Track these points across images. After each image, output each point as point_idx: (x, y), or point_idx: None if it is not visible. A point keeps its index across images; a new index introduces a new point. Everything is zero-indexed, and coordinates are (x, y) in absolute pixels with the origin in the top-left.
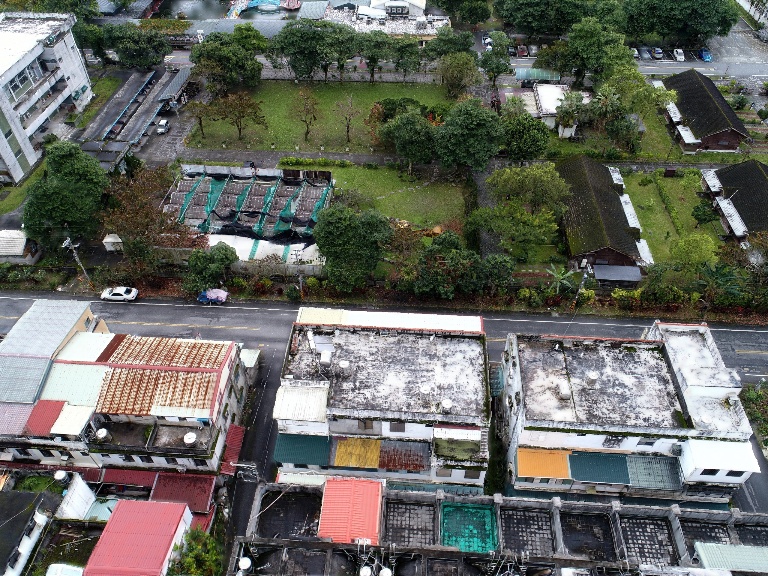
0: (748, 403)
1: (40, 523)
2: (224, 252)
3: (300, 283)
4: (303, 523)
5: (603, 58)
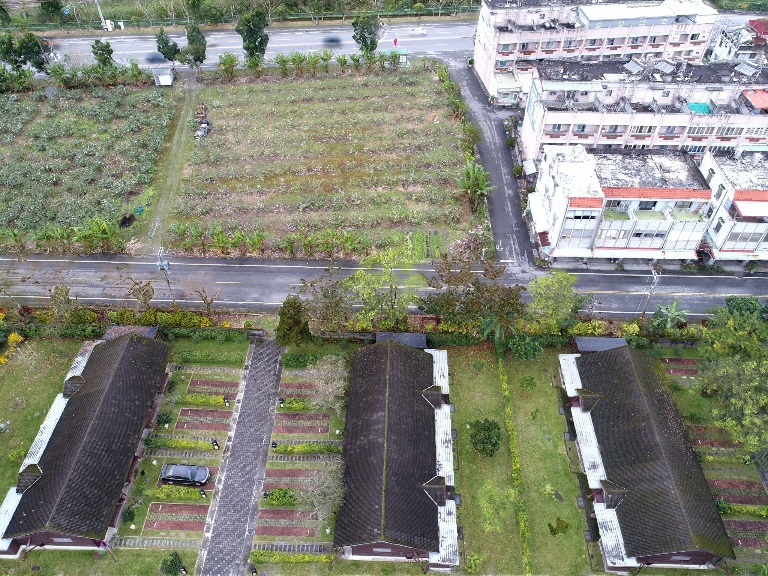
0: None
1: None
2: None
3: None
4: None
5: None
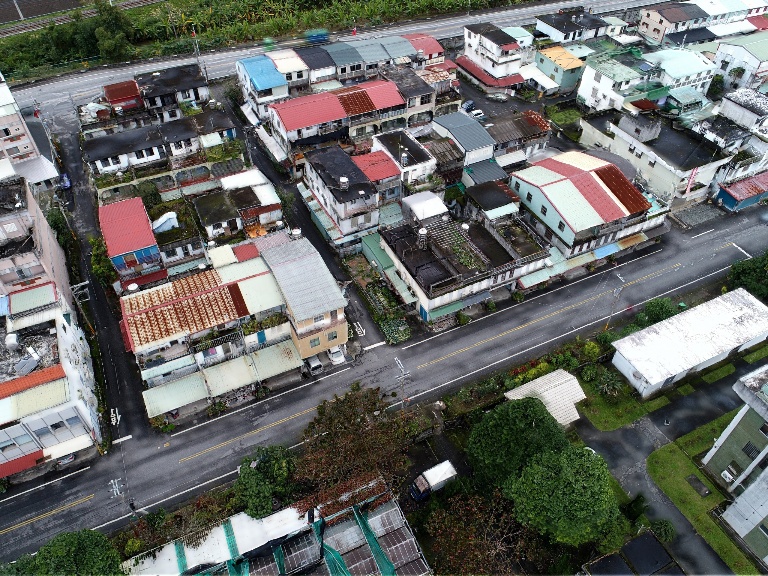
0: None
1: (208, 232)
2: (242, 478)
3: (135, 512)
4: (6, 255)
5: None
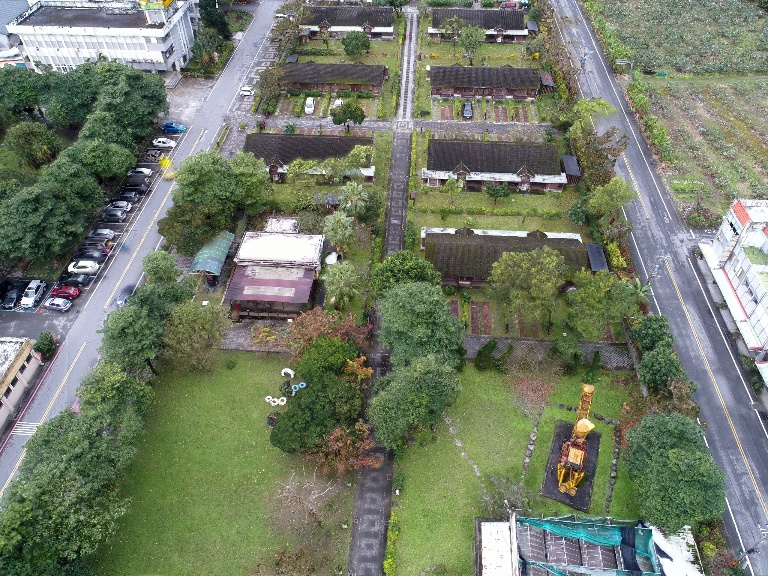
0: (699, 225)
1: None
2: None
3: None
4: None
5: (244, 181)
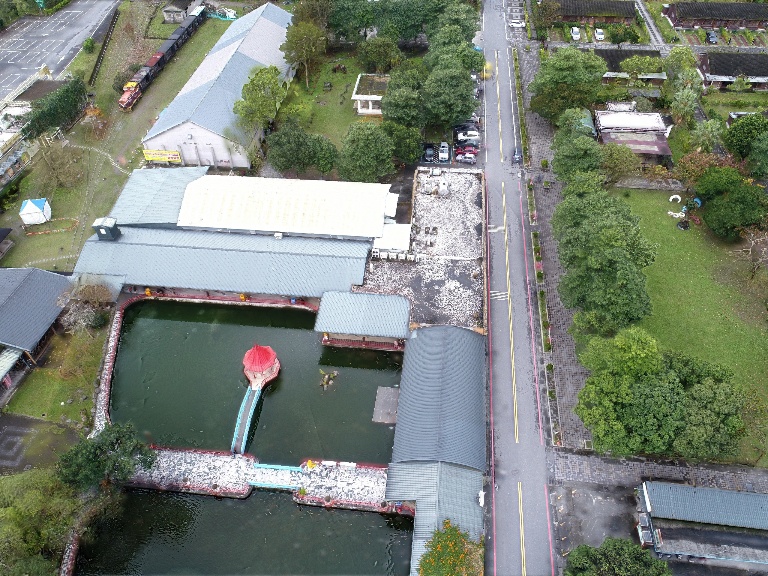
0: None
1: None
2: None
3: None
4: None
5: (594, 71)
